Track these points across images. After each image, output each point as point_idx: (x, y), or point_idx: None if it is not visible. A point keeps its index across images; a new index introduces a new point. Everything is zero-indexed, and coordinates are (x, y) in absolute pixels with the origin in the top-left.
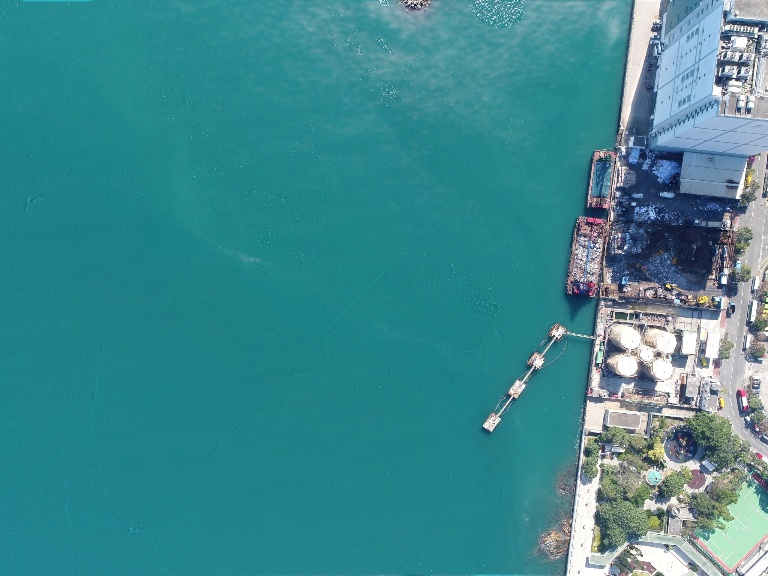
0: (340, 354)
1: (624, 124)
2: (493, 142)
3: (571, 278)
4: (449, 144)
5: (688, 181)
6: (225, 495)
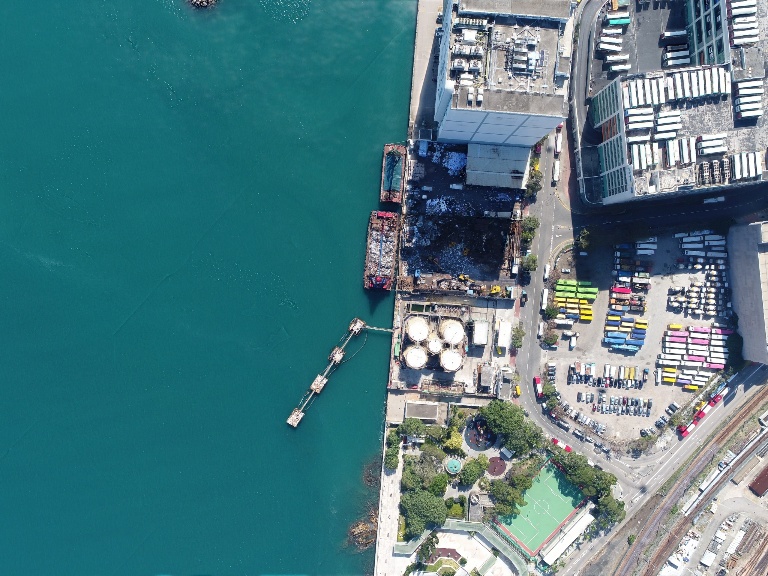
0: (127, 356)
1: (413, 117)
2: (286, 139)
3: (367, 272)
4: (242, 142)
5: (474, 172)
6: (18, 500)
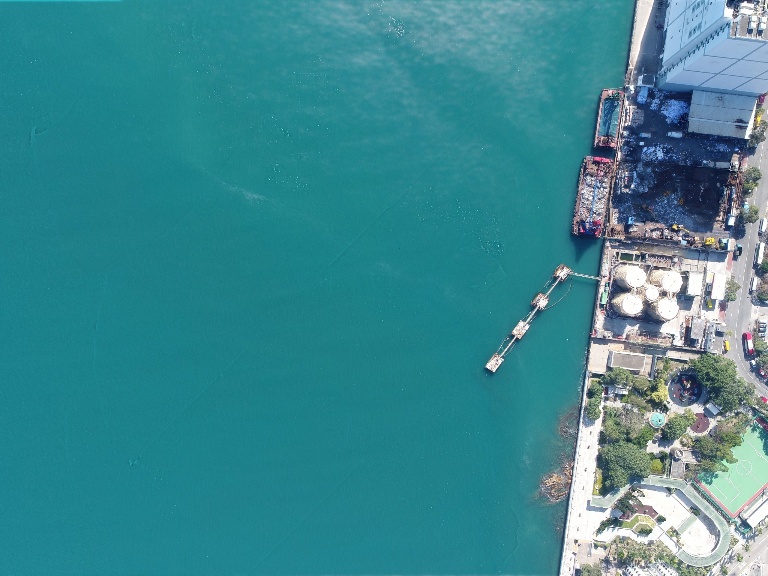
0: (343, 287)
1: (633, 63)
2: (500, 80)
3: (577, 218)
4: (456, 82)
5: (697, 120)
6: (225, 427)
